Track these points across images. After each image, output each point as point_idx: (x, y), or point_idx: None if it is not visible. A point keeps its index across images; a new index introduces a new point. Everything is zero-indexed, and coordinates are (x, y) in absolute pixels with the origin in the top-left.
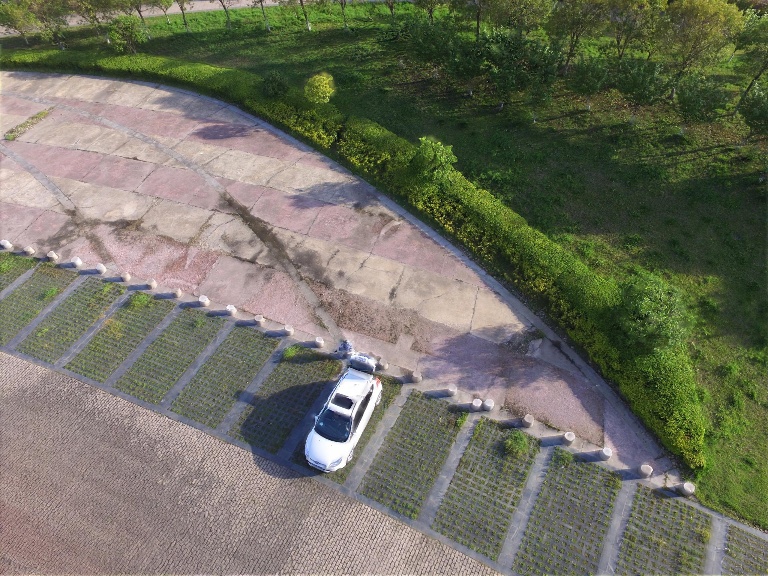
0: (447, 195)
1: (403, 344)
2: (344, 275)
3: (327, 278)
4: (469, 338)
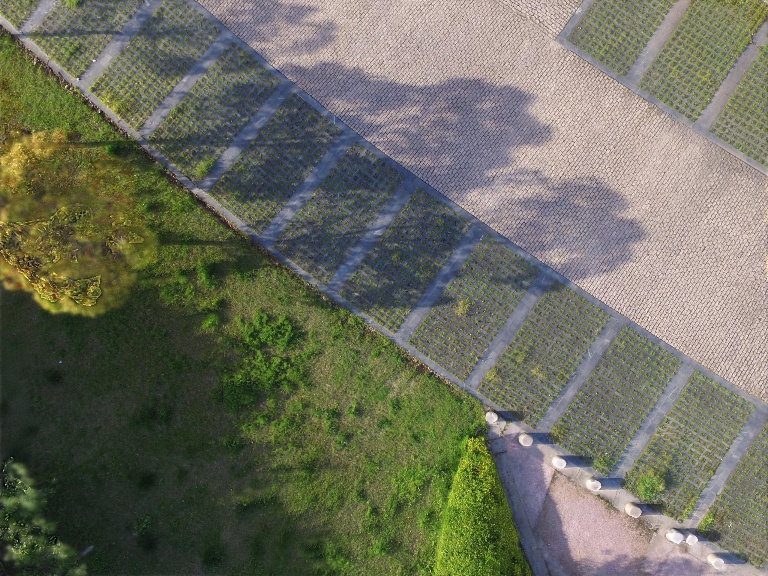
0: None
1: None
2: None
3: None
4: None
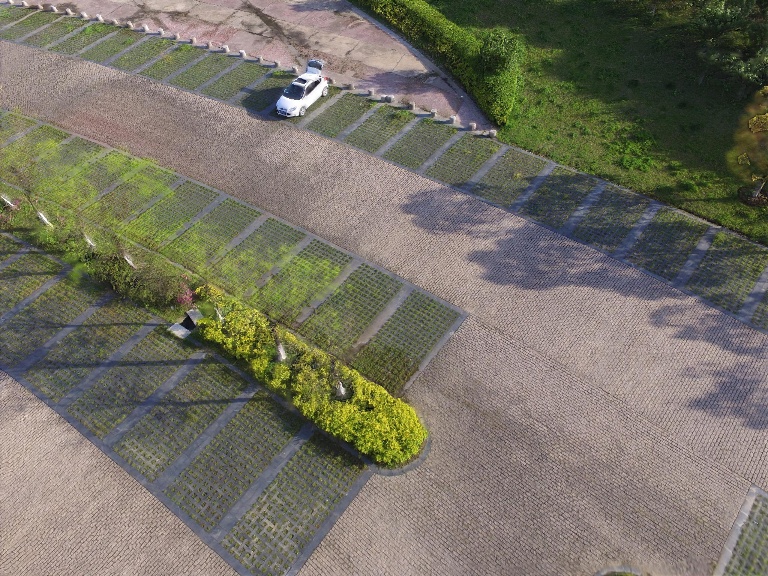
0: (397, 3)
1: (348, 74)
2: (318, 44)
3: (307, 45)
4: (390, 74)
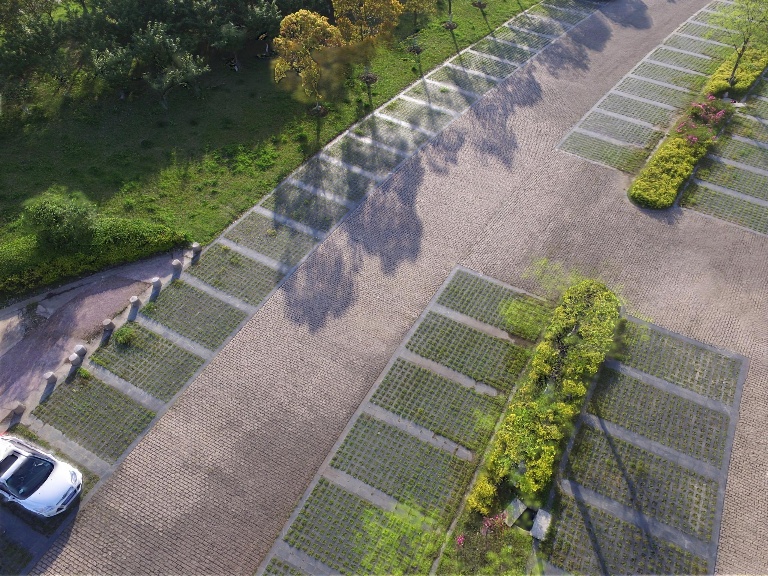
0: None
1: None
2: None
3: None
4: (2, 361)
